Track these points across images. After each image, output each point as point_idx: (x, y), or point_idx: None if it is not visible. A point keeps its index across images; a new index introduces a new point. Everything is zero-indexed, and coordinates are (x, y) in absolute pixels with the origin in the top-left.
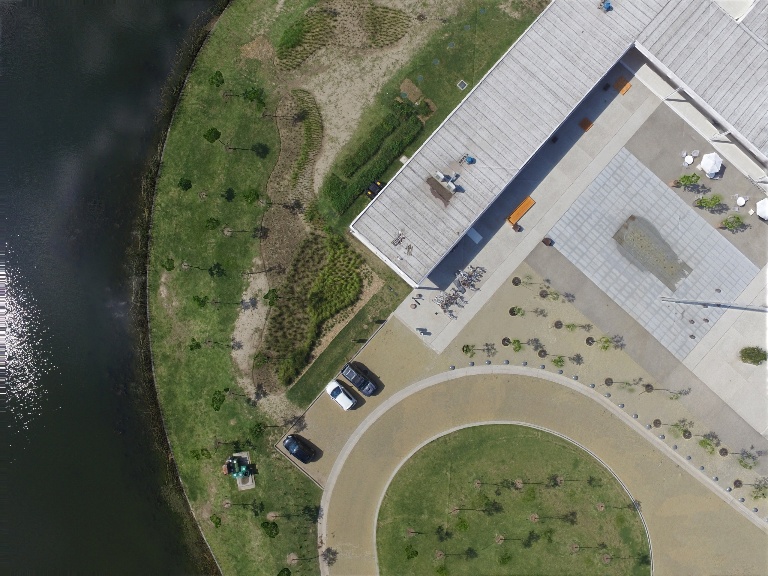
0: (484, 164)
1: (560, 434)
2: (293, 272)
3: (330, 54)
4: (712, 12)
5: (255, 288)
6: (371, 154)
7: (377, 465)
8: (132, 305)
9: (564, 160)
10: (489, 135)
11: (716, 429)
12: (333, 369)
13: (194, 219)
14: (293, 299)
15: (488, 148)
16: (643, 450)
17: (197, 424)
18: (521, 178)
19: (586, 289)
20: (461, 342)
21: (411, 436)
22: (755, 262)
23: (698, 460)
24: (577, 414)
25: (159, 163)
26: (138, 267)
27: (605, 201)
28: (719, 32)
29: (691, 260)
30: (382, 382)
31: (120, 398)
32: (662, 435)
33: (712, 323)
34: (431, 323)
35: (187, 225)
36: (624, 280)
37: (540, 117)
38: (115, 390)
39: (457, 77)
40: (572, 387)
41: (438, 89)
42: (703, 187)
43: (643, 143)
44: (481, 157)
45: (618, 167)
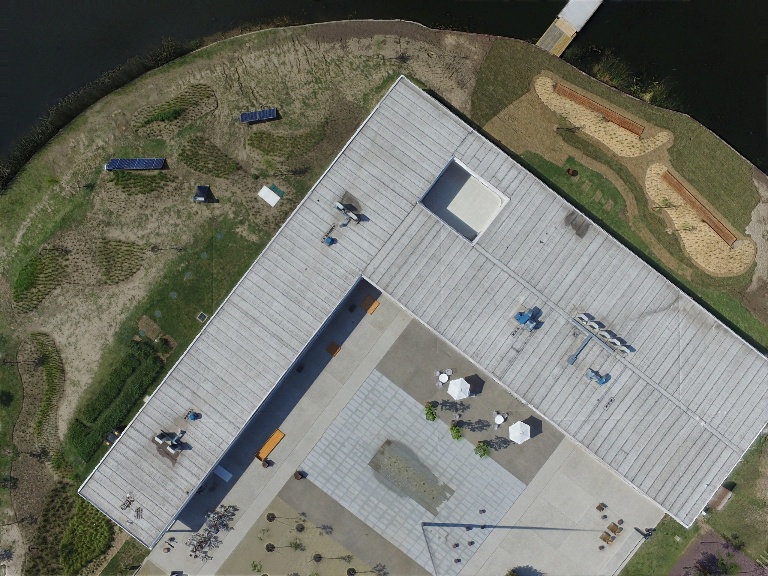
0: (210, 418)
1: None
2: (44, 523)
3: (66, 293)
4: (444, 235)
5: (9, 540)
6: (112, 398)
7: None
8: None
9: (312, 388)
10: (213, 387)
11: None
12: None
13: None
14: (46, 550)
15: (213, 401)
16: None
17: None
18: (268, 411)
19: (343, 520)
20: None
21: None
22: (521, 478)
23: None
24: None
25: None
26: None
27: (358, 427)
28: (452, 256)
29: (452, 481)
30: None
31: None
32: None
33: (478, 544)
34: (186, 565)
35: None
36: (383, 507)
37: (265, 364)
38: None
39: (196, 309)
40: None
41: (177, 324)
42: (461, 404)
43: (395, 363)
44: (206, 411)
45: (370, 391)
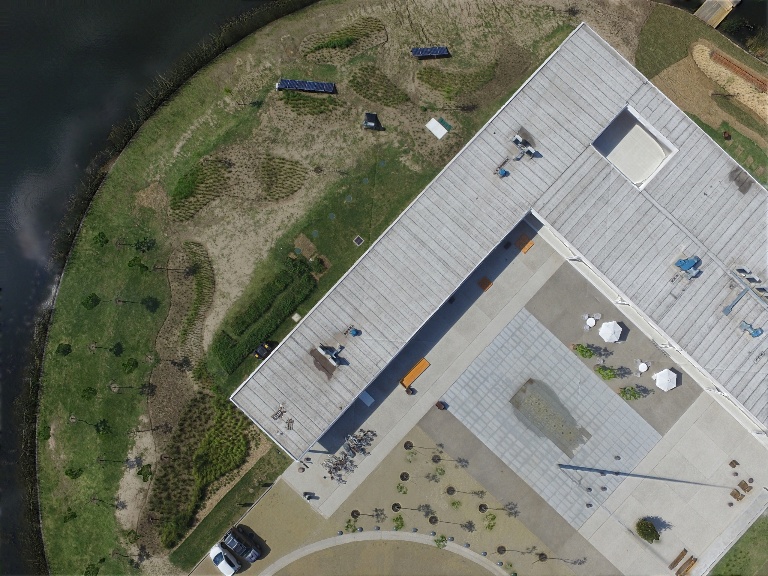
0: (370, 336)
1: None
2: (179, 432)
3: (224, 205)
4: (613, 179)
5: (141, 447)
6: (262, 312)
7: None
8: (22, 453)
9: (461, 321)
10: (376, 306)
11: None
12: (218, 532)
13: (83, 371)
14: (179, 460)
15: (375, 319)
16: None
17: None
18: (416, 339)
19: (480, 454)
20: (350, 507)
21: None
22: (657, 428)
23: None
24: None
25: (51, 310)
26: (28, 416)
27: (503, 363)
28: (620, 200)
29: (590, 426)
30: (268, 546)
31: (8, 547)
32: None
33: (610, 491)
34: (319, 487)
35: (76, 376)
36: (520, 446)
37: (429, 288)
38: (3, 539)
39: (353, 232)
40: (463, 555)
41: (333, 245)
42: (605, 350)
43: (544, 304)
44: (367, 328)
45: (517, 328)
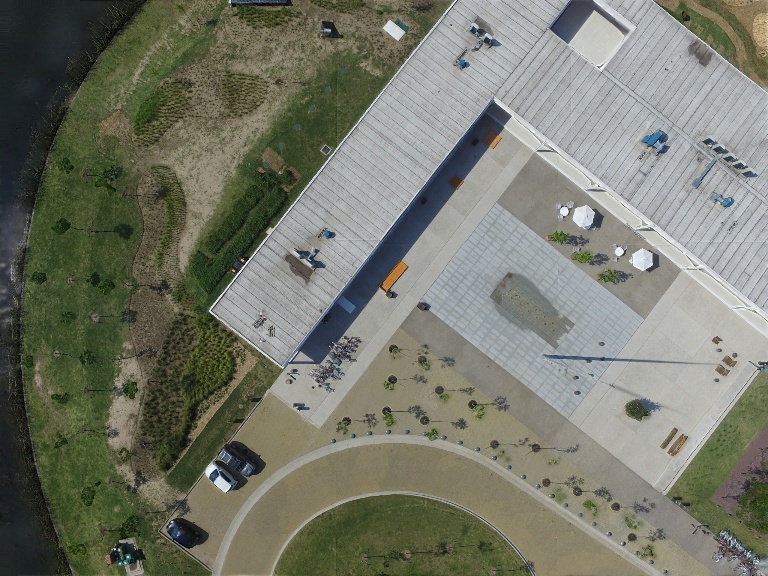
0: (344, 237)
1: (447, 500)
2: (164, 355)
3: (188, 126)
4: (573, 61)
5: (127, 374)
6: (236, 229)
7: (264, 543)
8: (10, 395)
9: (435, 221)
10: (347, 206)
11: (607, 484)
12: (211, 451)
13: (63, 305)
14: (166, 383)
15: (347, 220)
16: (533, 510)
17: (82, 512)
18: (392, 243)
19: (465, 352)
20: (340, 414)
21: (296, 512)
22: (638, 312)
23: (590, 516)
24: (464, 479)
25: (25, 249)
26: (12, 356)
27: (480, 260)
28: (581, 81)
29: (572, 314)
30: (263, 460)
31: (5, 489)
32: (552, 494)
33: (597, 377)
34: (308, 397)
35: (56, 312)
36: (504, 340)
37: (399, 184)
38: None
39: (320, 142)
40: (457, 452)
41: (301, 156)
42: (581, 238)
43: (516, 197)
44: (340, 230)
45: (492, 224)
